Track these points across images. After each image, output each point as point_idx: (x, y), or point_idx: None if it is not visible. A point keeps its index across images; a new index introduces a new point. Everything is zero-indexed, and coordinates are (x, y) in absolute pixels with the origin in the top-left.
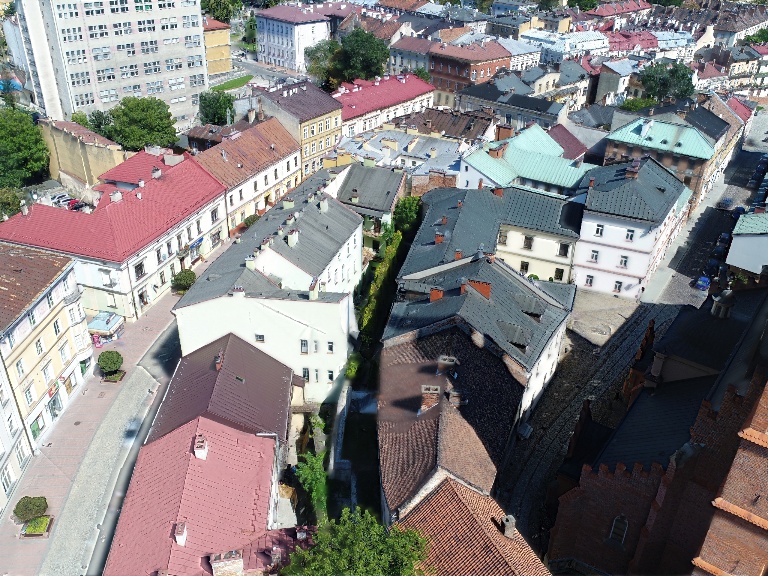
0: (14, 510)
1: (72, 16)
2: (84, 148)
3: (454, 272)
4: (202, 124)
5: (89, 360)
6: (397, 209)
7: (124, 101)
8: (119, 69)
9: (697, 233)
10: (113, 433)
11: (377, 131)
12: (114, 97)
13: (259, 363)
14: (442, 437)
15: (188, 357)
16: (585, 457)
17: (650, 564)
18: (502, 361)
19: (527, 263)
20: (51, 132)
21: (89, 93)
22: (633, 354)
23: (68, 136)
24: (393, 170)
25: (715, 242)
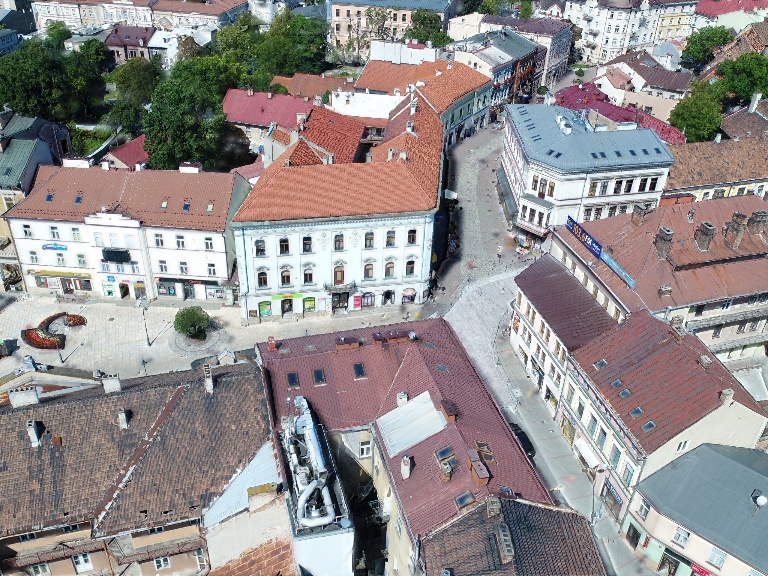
0: None
1: None
2: None
3: None
4: None
5: None
6: None
7: None
8: None
9: None
10: None
11: None
12: None
13: None
14: (759, 24)
15: None
16: None
17: None
18: None
19: None
20: None
21: None
22: None
23: None
24: None
25: None
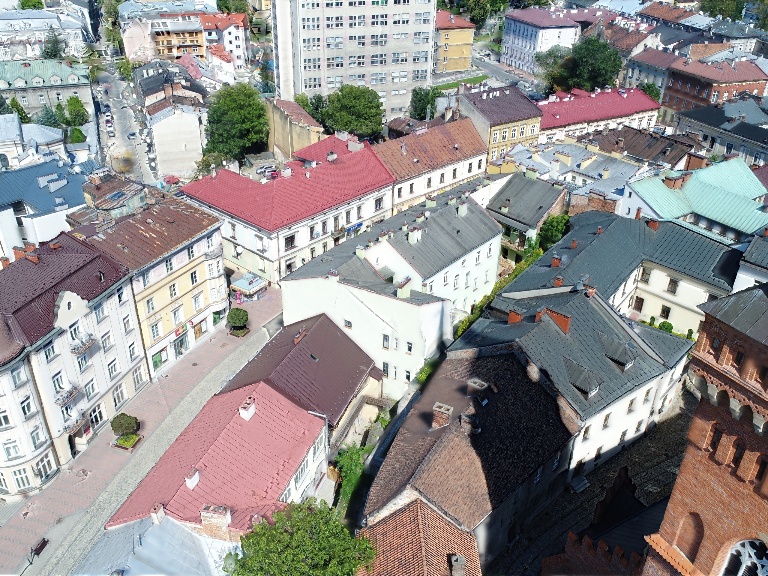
0: (111, 422)
1: (314, 7)
2: (291, 126)
3: (549, 299)
4: (410, 117)
5: (224, 313)
6: (544, 226)
7: (342, 88)
8: (348, 58)
9: None
10: (218, 380)
11: (558, 143)
12: (339, 84)
13: (341, 347)
14: (431, 458)
15: (287, 327)
16: None
17: None
18: (555, 401)
19: (669, 308)
20: (272, 109)
21: (318, 78)
22: None
23: (282, 114)
24: (553, 185)
25: None
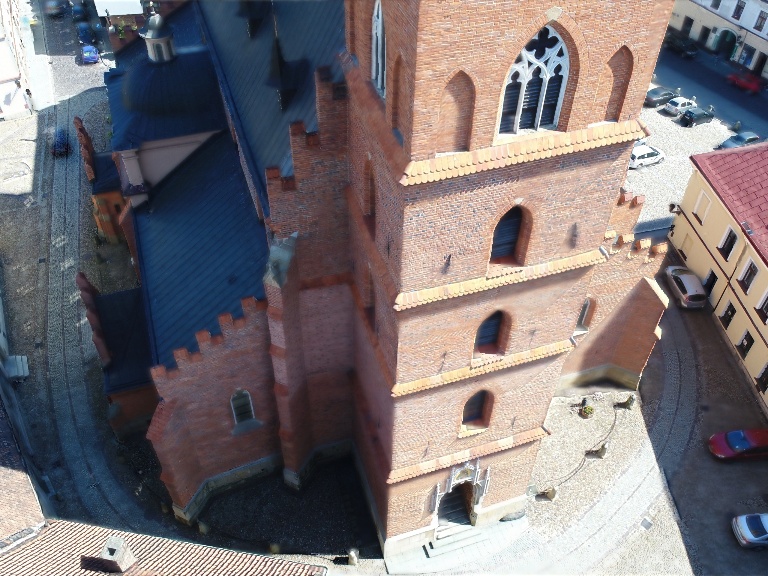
0: None
1: None
2: None
3: None
4: None
5: None
6: None
7: None
8: None
9: (39, 1)
10: None
11: None
12: None
13: None
14: None
15: None
16: (128, 348)
17: (302, 417)
18: None
19: None
20: None
21: None
22: (76, 179)
23: None
24: None
25: (66, 3)
